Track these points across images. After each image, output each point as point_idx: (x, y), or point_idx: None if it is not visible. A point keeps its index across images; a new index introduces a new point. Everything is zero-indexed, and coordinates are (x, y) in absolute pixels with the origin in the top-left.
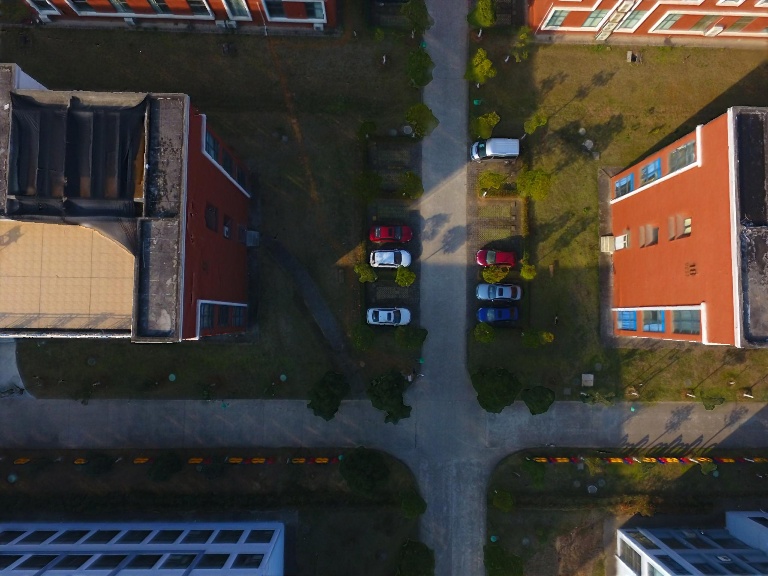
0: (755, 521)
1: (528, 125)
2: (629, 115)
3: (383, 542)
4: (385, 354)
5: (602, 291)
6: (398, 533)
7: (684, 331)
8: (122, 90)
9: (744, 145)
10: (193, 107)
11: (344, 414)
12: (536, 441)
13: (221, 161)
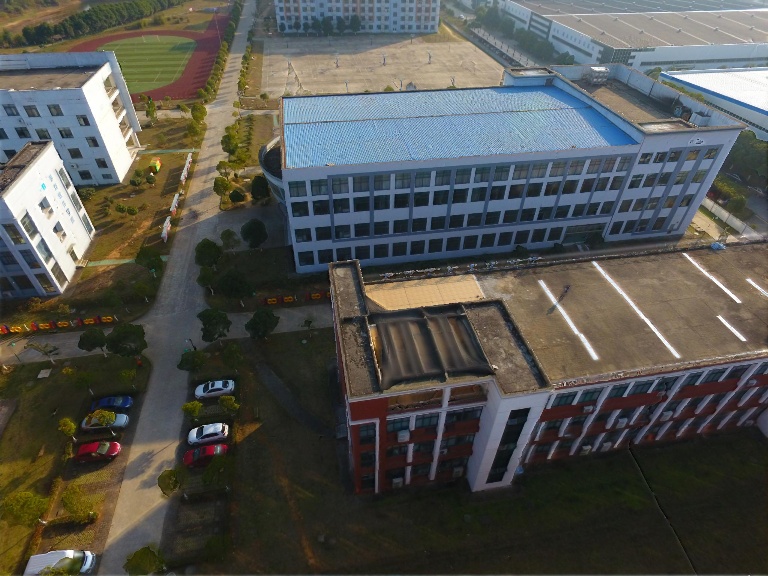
0: None
1: None
2: None
3: None
4: (221, 366)
5: None
6: None
7: None
8: (514, 557)
9: None
10: (431, 555)
11: None
12: (107, 332)
13: None
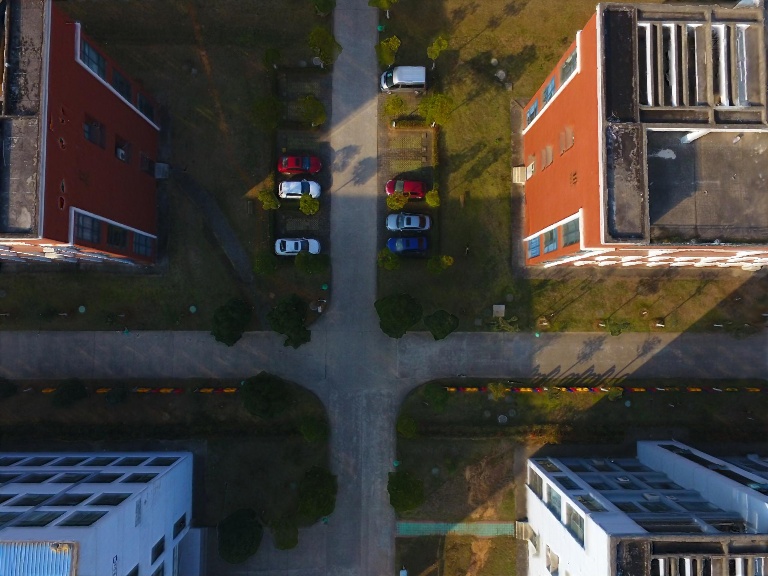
0: (662, 447)
1: (431, 50)
2: (542, 46)
3: (292, 471)
4: (295, 285)
5: (514, 222)
6: (307, 462)
7: (570, 243)
8: None
9: (612, 42)
10: (102, 40)
11: (254, 345)
12: (447, 372)
13: (109, 79)
